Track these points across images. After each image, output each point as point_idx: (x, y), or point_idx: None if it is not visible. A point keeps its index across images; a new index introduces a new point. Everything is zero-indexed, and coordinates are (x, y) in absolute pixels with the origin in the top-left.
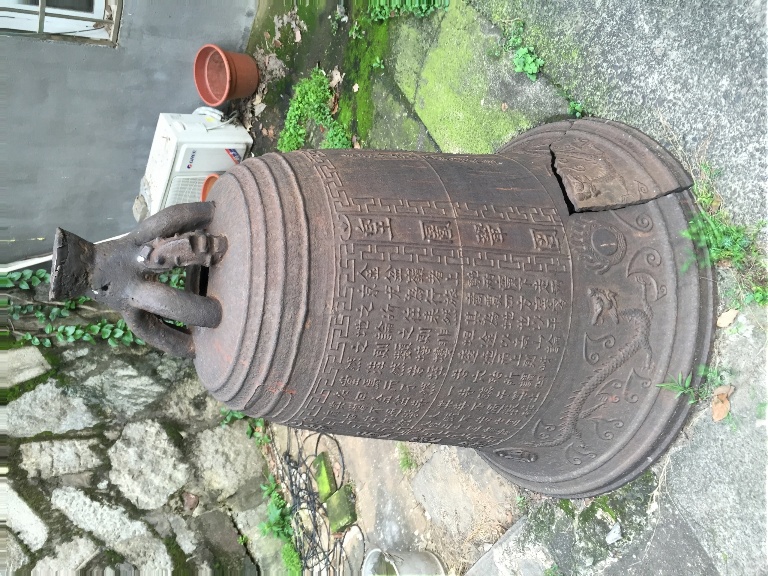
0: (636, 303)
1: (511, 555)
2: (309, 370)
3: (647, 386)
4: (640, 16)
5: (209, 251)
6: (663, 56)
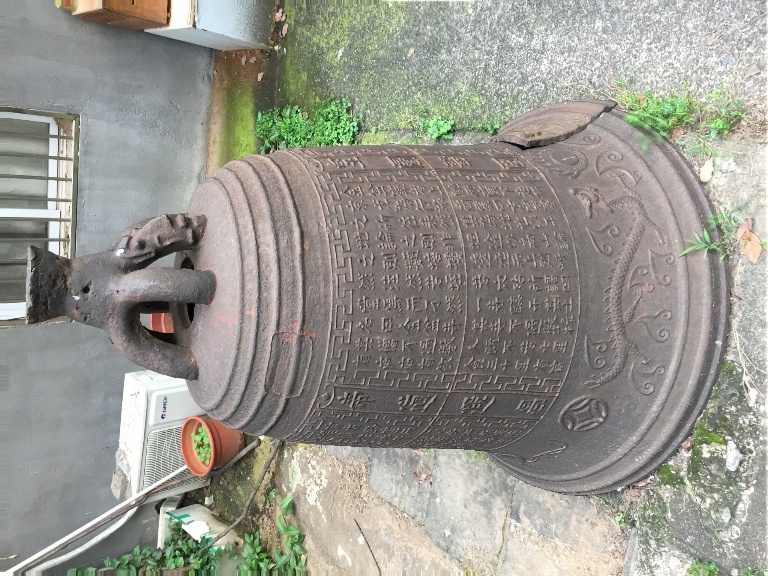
0: (619, 192)
1: None
2: (322, 299)
3: (672, 261)
4: (512, 37)
5: (189, 226)
6: (543, 46)
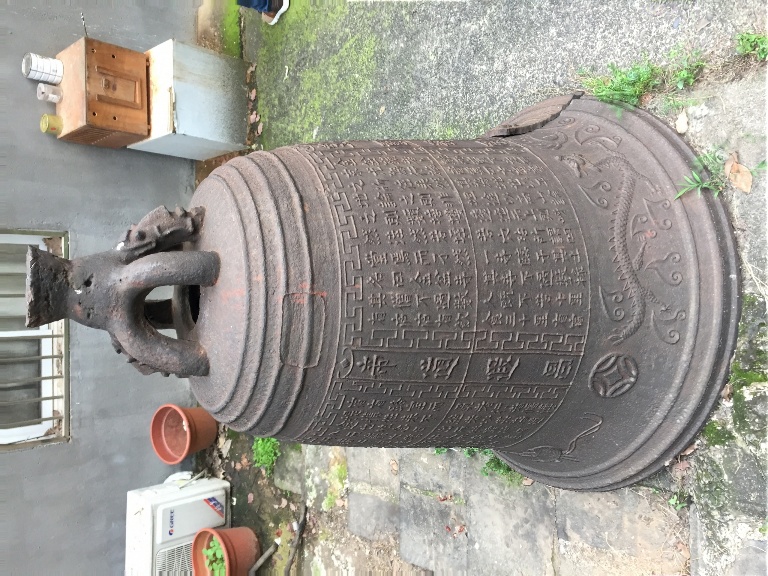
0: (603, 155)
1: (717, 572)
2: (329, 256)
3: (668, 206)
4: (475, 67)
5: (188, 215)
6: (505, 65)
